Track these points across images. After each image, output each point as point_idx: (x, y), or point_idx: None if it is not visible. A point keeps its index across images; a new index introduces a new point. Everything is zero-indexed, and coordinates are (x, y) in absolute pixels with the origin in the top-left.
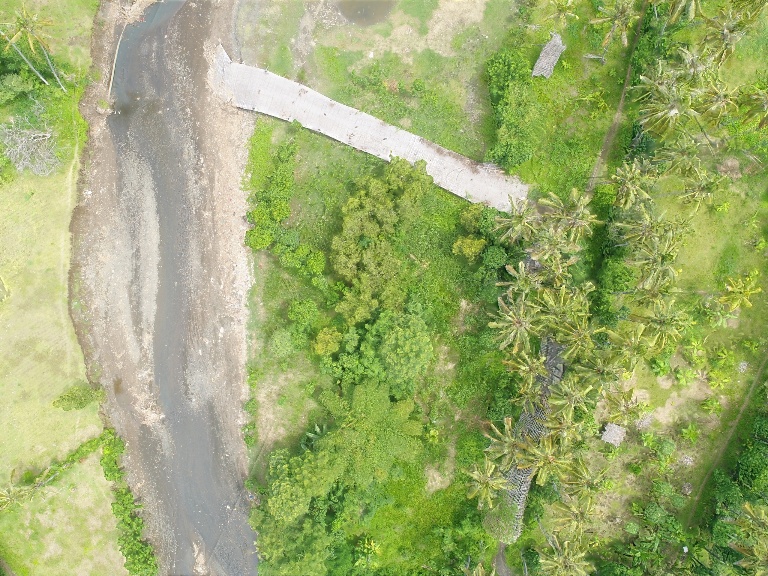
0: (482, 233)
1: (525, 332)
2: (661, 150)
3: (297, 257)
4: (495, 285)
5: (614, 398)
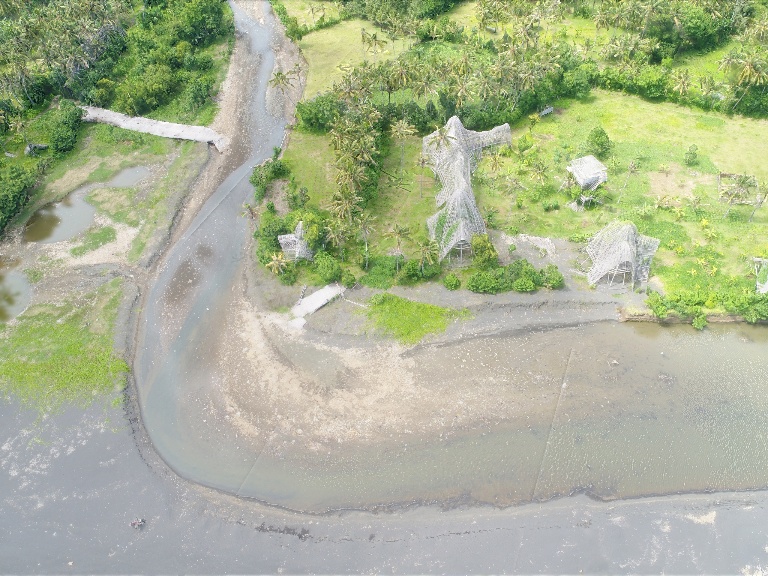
0: None
1: None
2: None
3: None
4: None
5: None
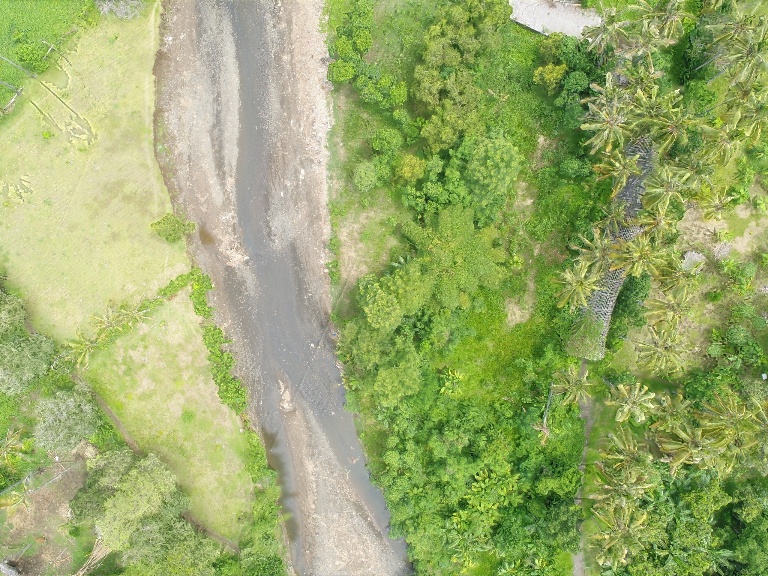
0: (562, 61)
1: (619, 129)
2: None
3: (380, 88)
4: (580, 102)
5: (707, 196)
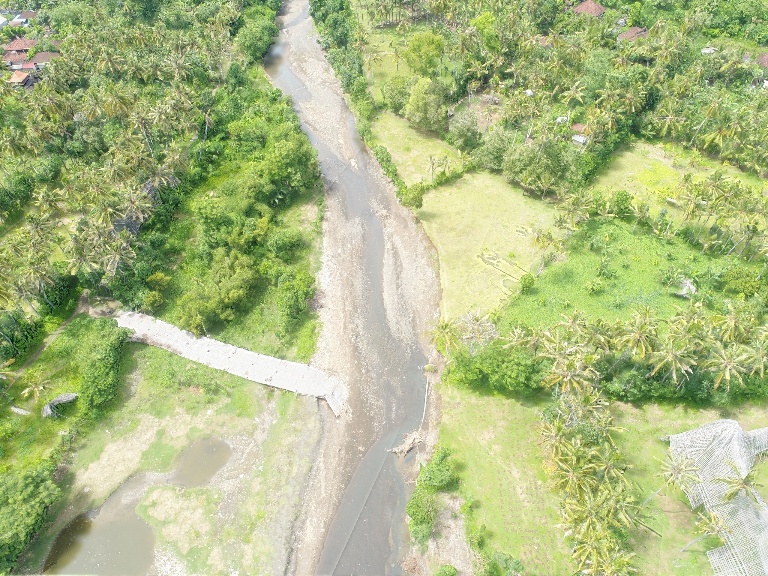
0: None
1: None
2: (5, 278)
3: None
4: None
5: None
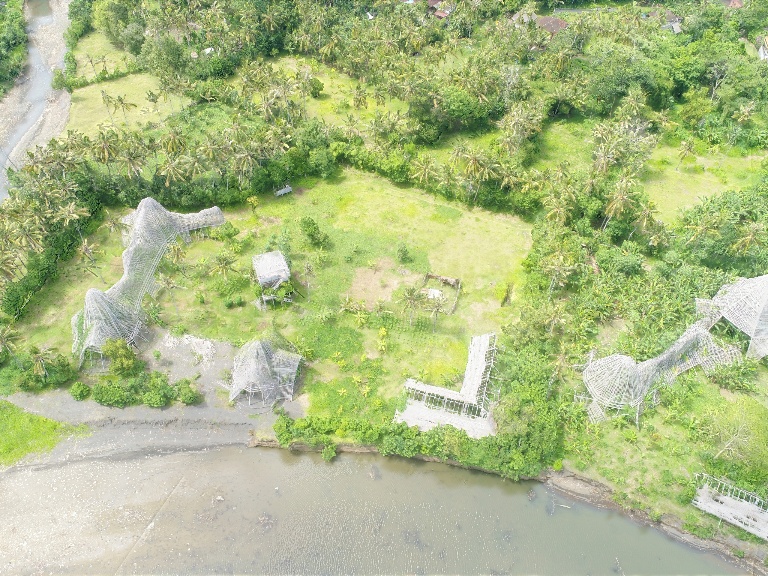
0: None
1: None
2: None
3: None
4: None
5: None
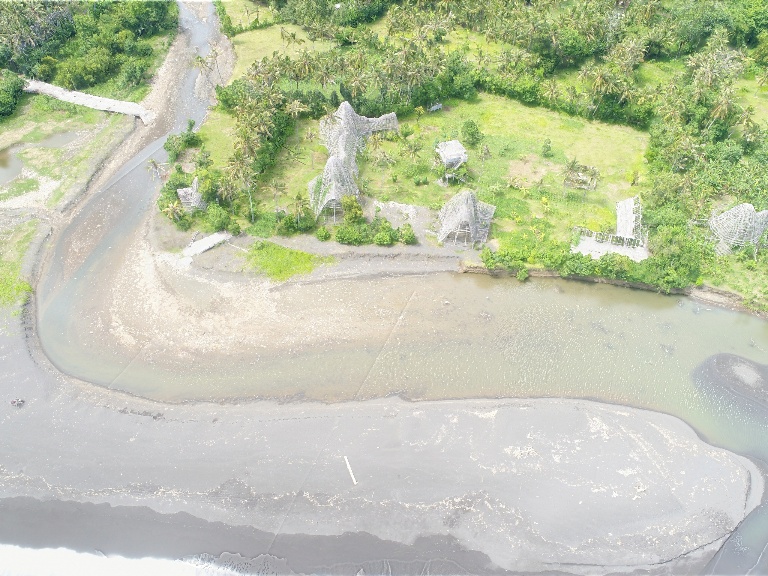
0: None
1: None
2: None
3: None
4: None
5: None
